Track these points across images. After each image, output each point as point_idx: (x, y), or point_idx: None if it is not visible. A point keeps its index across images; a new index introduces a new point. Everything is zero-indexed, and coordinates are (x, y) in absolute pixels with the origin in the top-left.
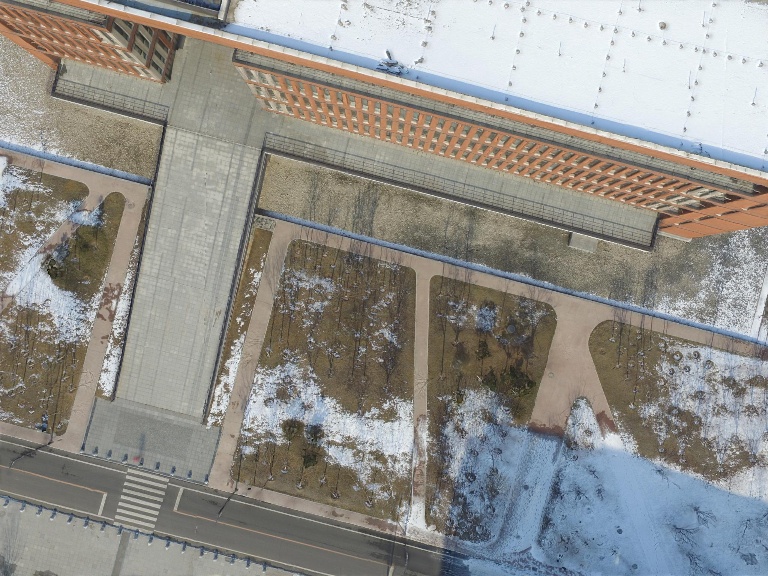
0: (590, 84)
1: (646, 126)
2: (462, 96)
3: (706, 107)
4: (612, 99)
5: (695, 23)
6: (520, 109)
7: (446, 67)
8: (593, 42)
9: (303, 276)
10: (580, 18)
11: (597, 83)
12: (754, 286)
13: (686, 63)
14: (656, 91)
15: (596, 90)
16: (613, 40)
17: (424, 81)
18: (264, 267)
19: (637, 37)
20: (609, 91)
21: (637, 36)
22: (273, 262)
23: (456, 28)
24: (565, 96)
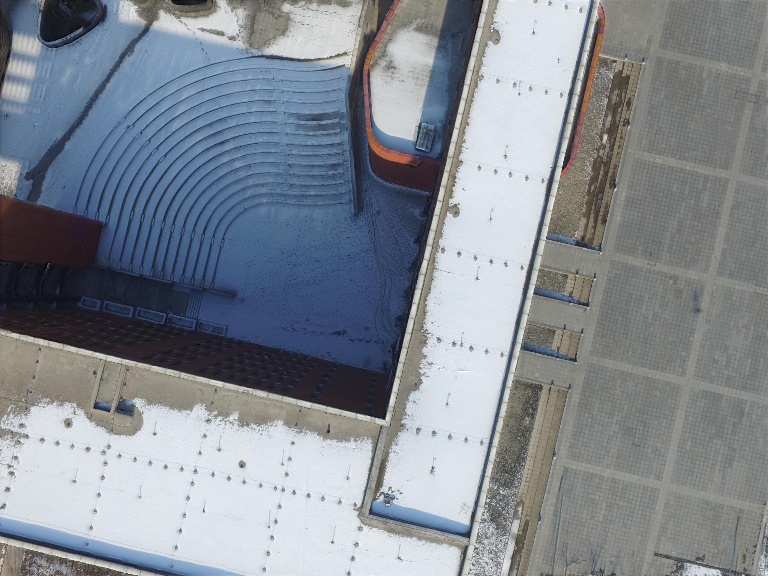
0: (171, 526)
1: (226, 567)
2: (37, 548)
3: (286, 546)
4: (193, 540)
5: (274, 462)
6: (95, 559)
7: (29, 512)
8: (173, 483)
9: (44, 562)
10: (160, 461)
11: (177, 525)
12: (495, 561)
13: (266, 502)
14: (236, 531)
15: (177, 531)
16: (193, 481)
17: (6, 528)
18: (6, 553)
19: (217, 477)
20: (190, 532)
21: (217, 476)
22: (14, 548)
23: (39, 472)
24: (146, 538)
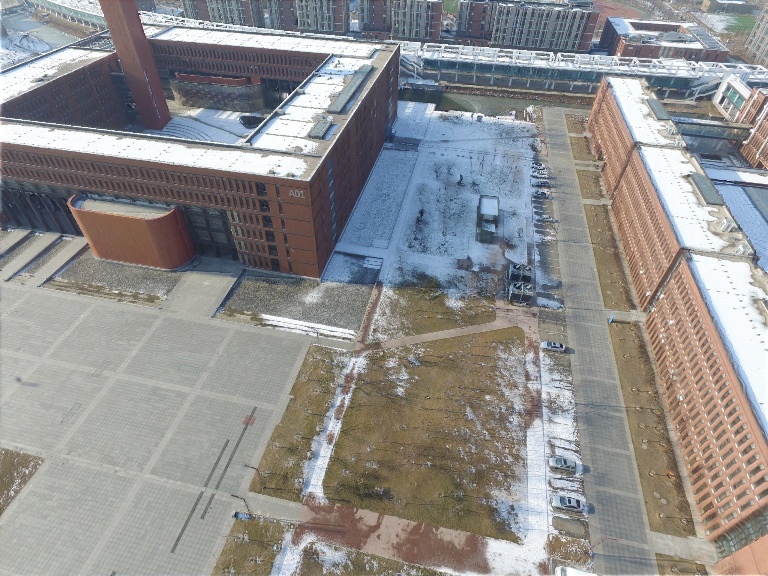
0: None
1: None
2: None
3: None
4: None
5: None
6: None
7: None
8: None
9: None
10: None
11: None
12: None
13: None
14: None
15: None
16: None
17: None
18: None
19: None
20: None
21: None
22: None
23: None
24: None
